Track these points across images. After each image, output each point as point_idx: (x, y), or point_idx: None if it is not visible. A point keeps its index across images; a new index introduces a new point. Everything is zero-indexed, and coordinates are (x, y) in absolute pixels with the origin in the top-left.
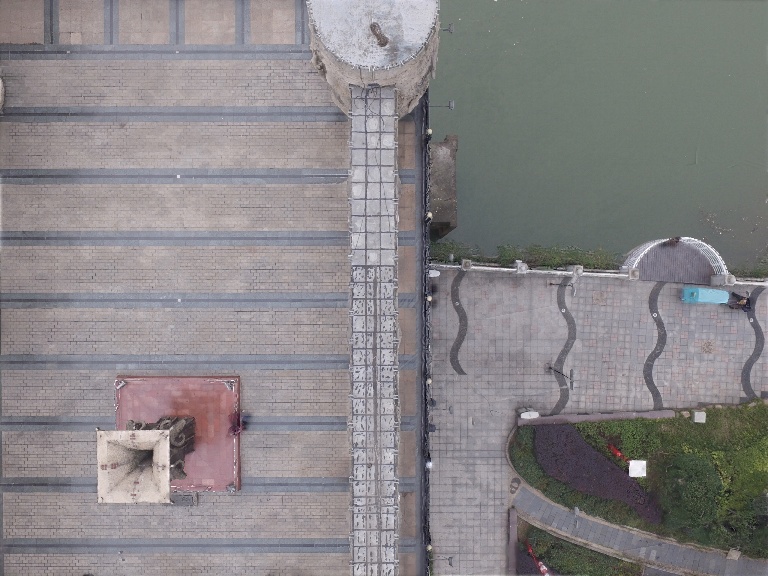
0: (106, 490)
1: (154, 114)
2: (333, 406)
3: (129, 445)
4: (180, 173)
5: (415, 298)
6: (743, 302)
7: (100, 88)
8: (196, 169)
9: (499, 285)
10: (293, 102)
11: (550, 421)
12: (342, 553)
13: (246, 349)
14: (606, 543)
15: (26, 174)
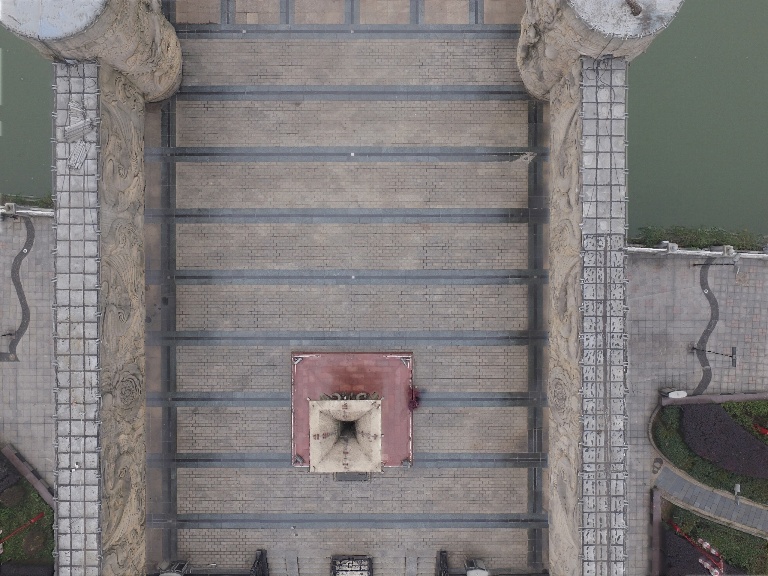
0: (318, 459)
1: (329, 93)
2: (505, 382)
3: (339, 415)
4: (354, 151)
5: None
6: None
7: (276, 67)
8: (370, 147)
9: (642, 266)
10: (466, 81)
11: (694, 401)
12: (513, 528)
13: (419, 325)
14: (749, 523)
15: (202, 152)
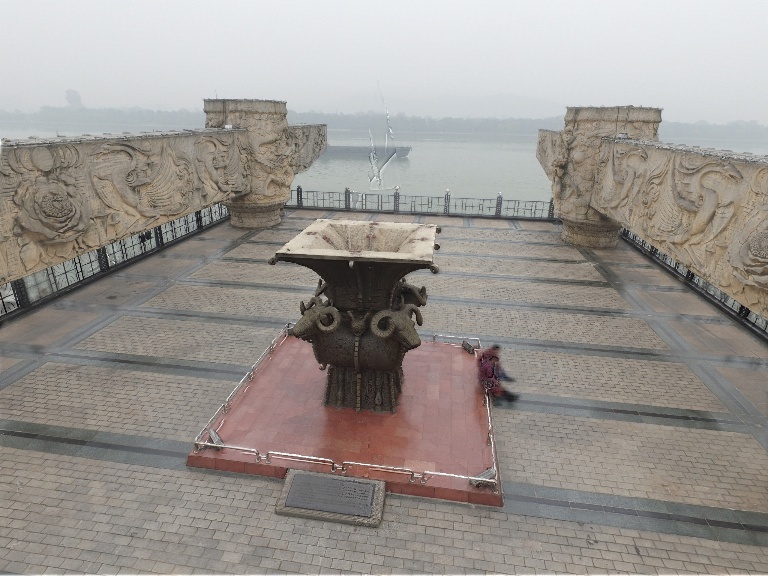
0: None
1: None
2: (672, 397)
3: (360, 235)
4: None
5: (725, 320)
6: None
7: None
8: None
9: None
10: None
11: None
12: None
13: (489, 332)
14: None
15: None
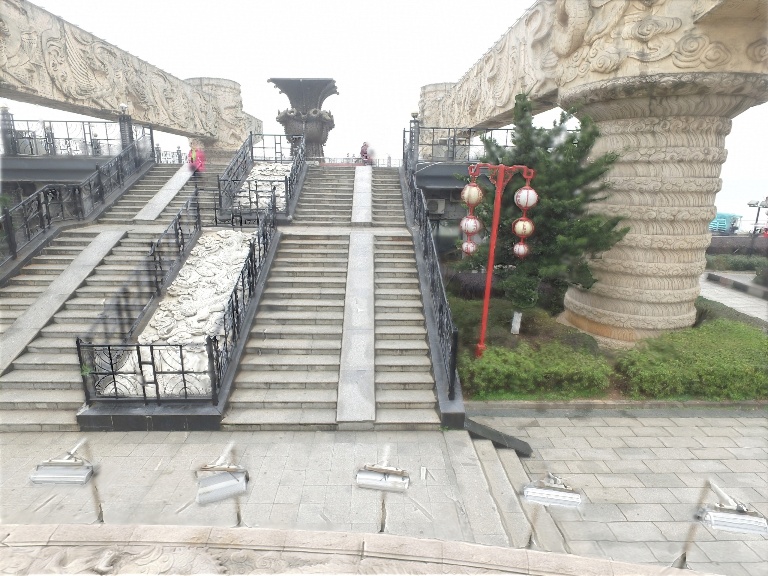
0: None
1: None
2: None
3: None
4: None
5: None
6: (762, 229)
7: None
8: None
9: None
10: None
11: None
12: None
13: None
14: None
15: None
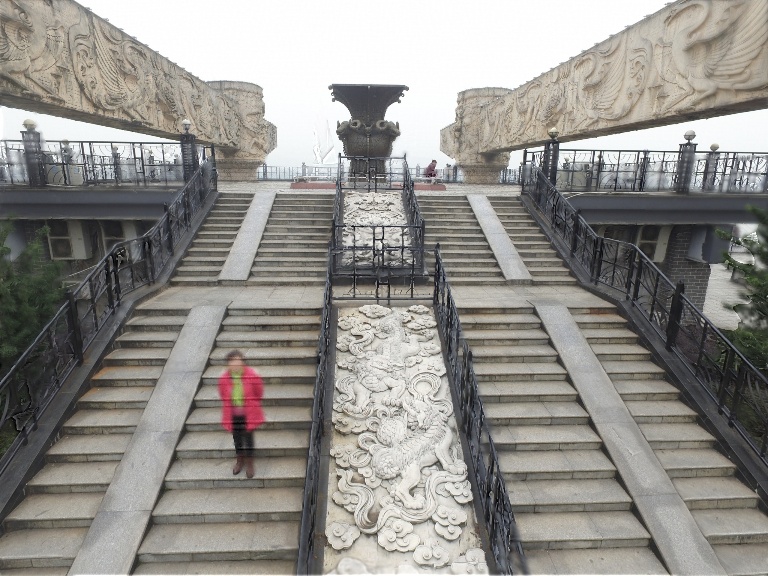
0: None
1: None
2: None
3: None
4: None
5: None
6: None
7: None
8: None
9: None
10: None
11: None
12: None
13: None
14: None
15: None
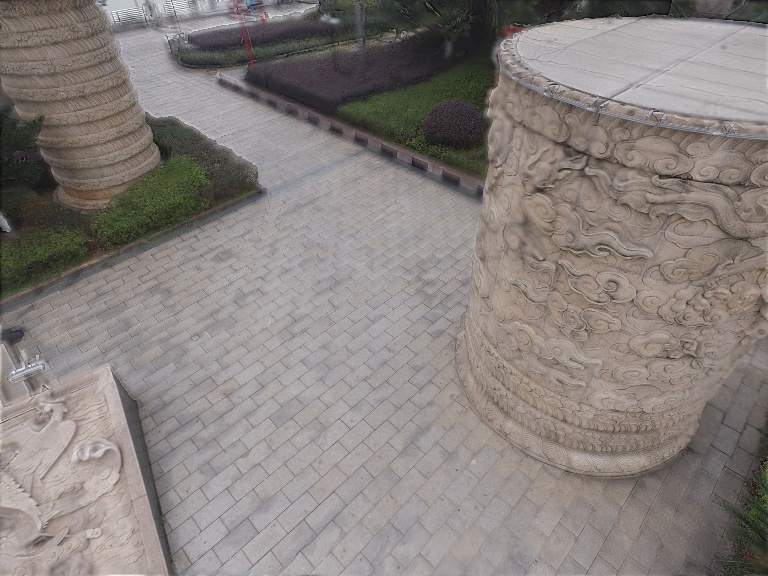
0: None
1: None
2: None
3: None
4: None
5: None
6: None
7: None
8: None
9: None
10: None
11: None
12: None
13: None
14: None
15: None
